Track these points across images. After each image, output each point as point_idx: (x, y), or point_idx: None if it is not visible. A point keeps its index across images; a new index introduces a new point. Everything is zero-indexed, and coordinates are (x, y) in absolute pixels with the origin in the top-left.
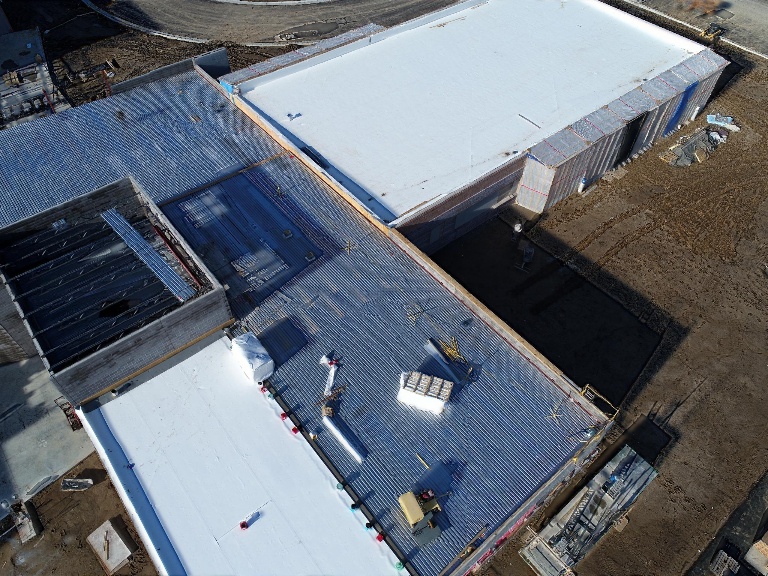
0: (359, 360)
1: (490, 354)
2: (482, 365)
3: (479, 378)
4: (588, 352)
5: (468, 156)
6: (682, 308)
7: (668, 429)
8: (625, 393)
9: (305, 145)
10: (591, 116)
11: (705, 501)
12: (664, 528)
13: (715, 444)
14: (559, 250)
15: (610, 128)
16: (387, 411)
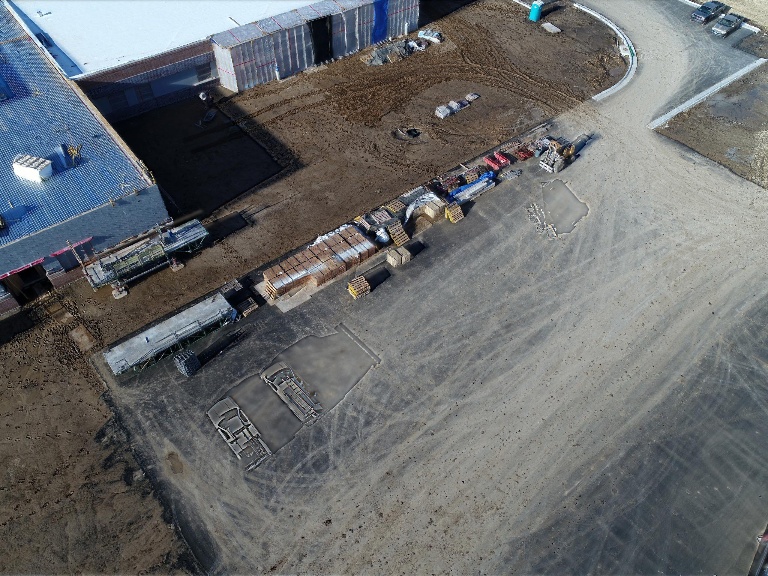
0: (2, 154)
1: (101, 153)
2: (91, 159)
3: (83, 165)
4: (219, 176)
5: (169, 42)
6: (311, 152)
7: (250, 220)
8: (231, 199)
9: (42, 32)
10: (278, 16)
11: (249, 258)
12: (208, 271)
13: (279, 228)
14: (238, 116)
15: (289, 24)
16: (3, 180)
